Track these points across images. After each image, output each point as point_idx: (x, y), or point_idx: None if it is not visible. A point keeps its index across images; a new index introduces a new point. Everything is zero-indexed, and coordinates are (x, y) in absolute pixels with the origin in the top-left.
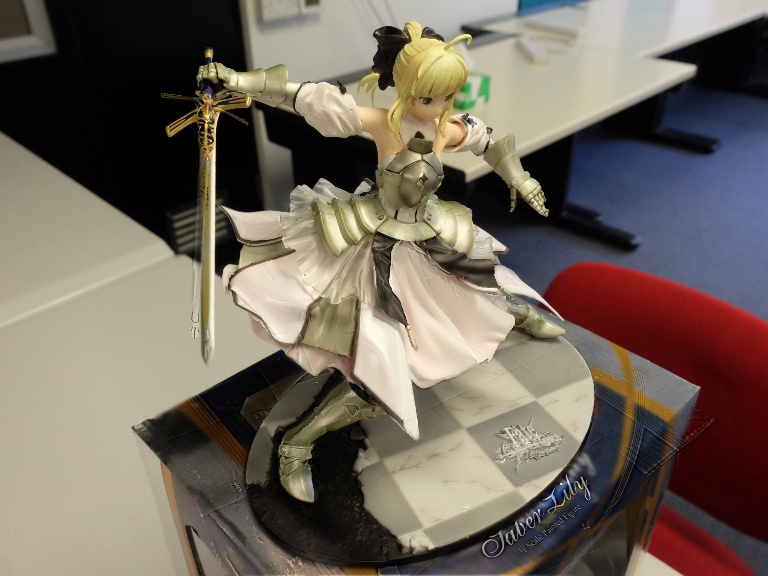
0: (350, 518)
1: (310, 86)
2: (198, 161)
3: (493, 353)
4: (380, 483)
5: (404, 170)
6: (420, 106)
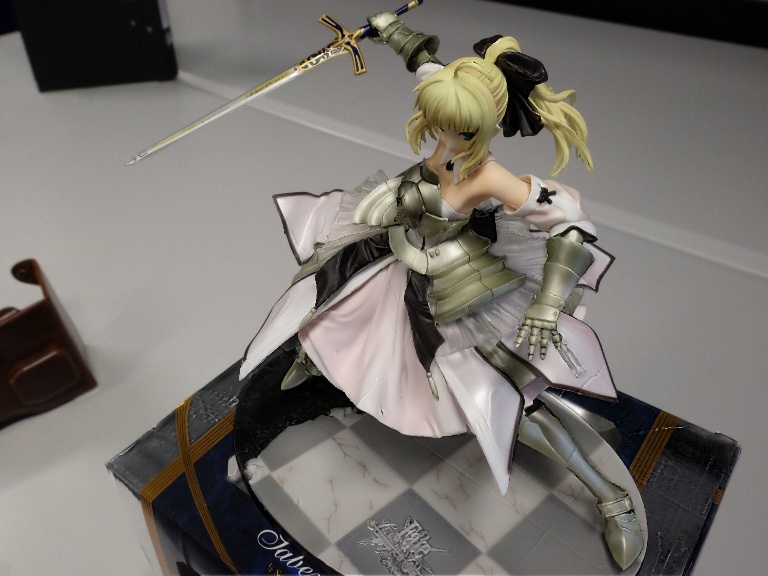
0: (278, 422)
1: (433, 66)
2: (279, 74)
3: (418, 434)
4: (318, 432)
5: (403, 183)
6: (438, 129)
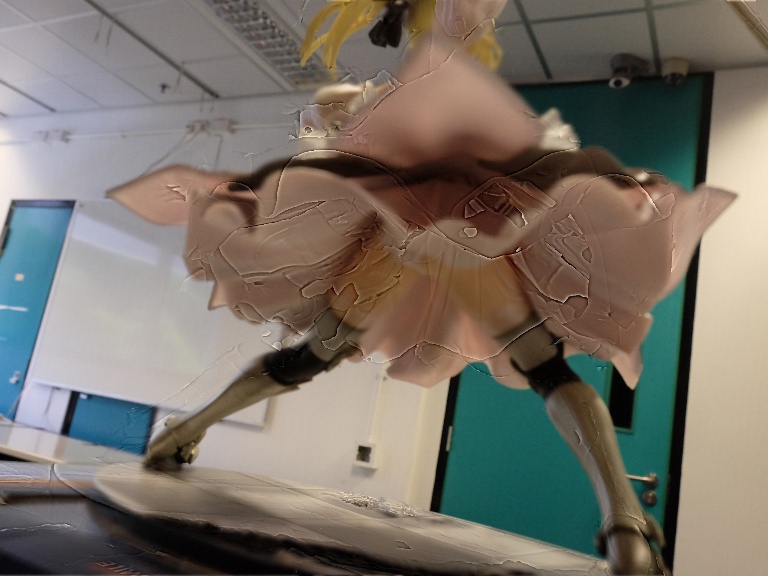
0: None
1: None
2: None
3: None
4: None
5: None
6: None
